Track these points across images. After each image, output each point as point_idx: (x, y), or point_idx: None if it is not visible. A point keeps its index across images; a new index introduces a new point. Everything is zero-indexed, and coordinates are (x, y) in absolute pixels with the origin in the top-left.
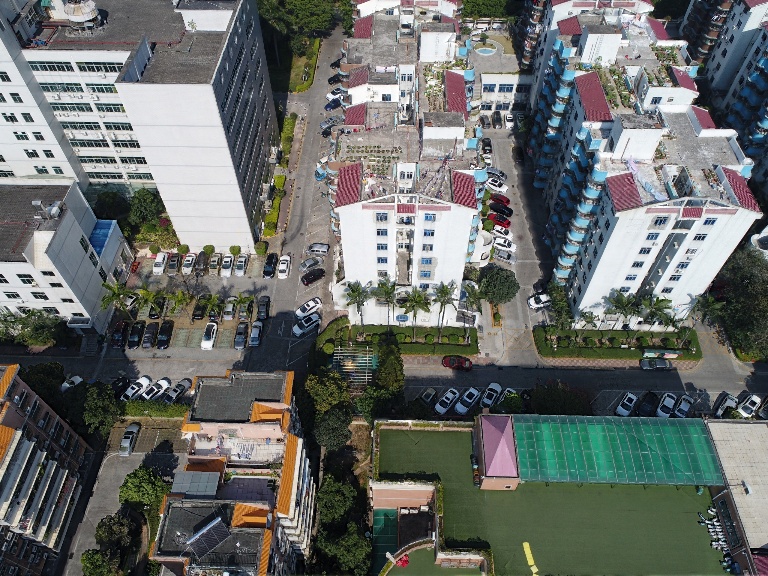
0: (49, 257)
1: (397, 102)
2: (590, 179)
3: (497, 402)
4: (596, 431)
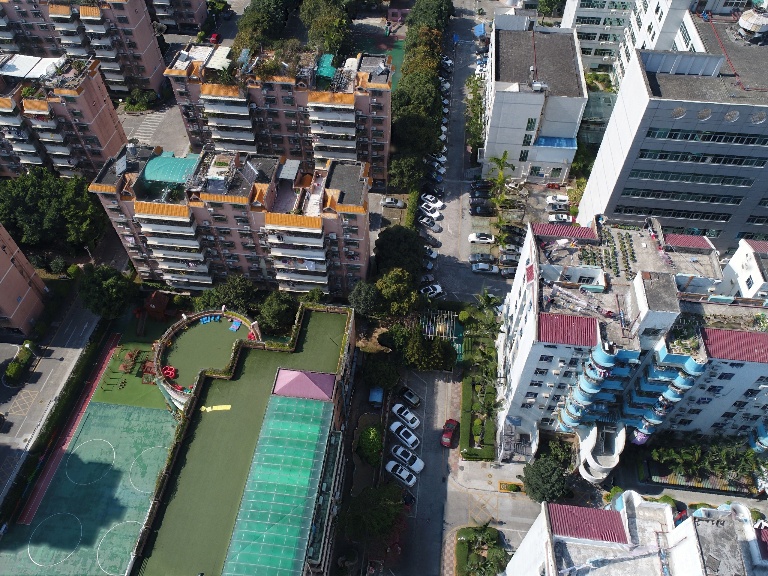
0: (496, 96)
1: (723, 278)
2: (619, 493)
3: (400, 462)
4: (302, 475)
